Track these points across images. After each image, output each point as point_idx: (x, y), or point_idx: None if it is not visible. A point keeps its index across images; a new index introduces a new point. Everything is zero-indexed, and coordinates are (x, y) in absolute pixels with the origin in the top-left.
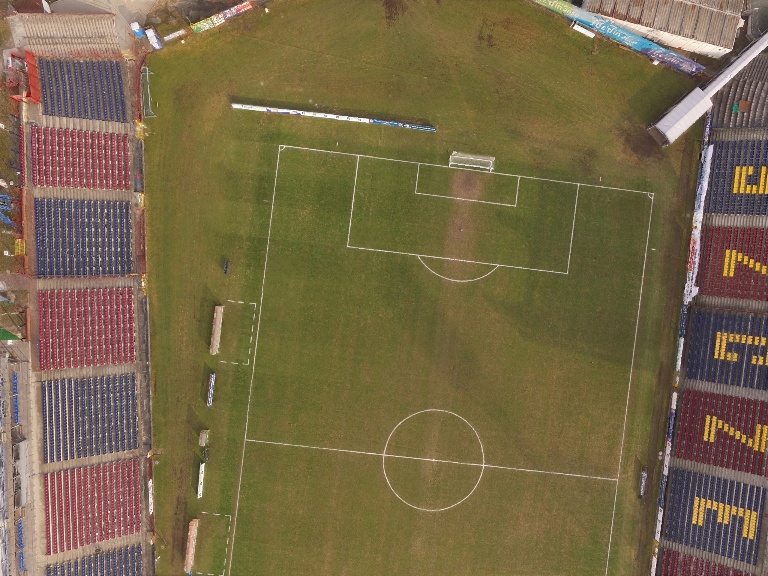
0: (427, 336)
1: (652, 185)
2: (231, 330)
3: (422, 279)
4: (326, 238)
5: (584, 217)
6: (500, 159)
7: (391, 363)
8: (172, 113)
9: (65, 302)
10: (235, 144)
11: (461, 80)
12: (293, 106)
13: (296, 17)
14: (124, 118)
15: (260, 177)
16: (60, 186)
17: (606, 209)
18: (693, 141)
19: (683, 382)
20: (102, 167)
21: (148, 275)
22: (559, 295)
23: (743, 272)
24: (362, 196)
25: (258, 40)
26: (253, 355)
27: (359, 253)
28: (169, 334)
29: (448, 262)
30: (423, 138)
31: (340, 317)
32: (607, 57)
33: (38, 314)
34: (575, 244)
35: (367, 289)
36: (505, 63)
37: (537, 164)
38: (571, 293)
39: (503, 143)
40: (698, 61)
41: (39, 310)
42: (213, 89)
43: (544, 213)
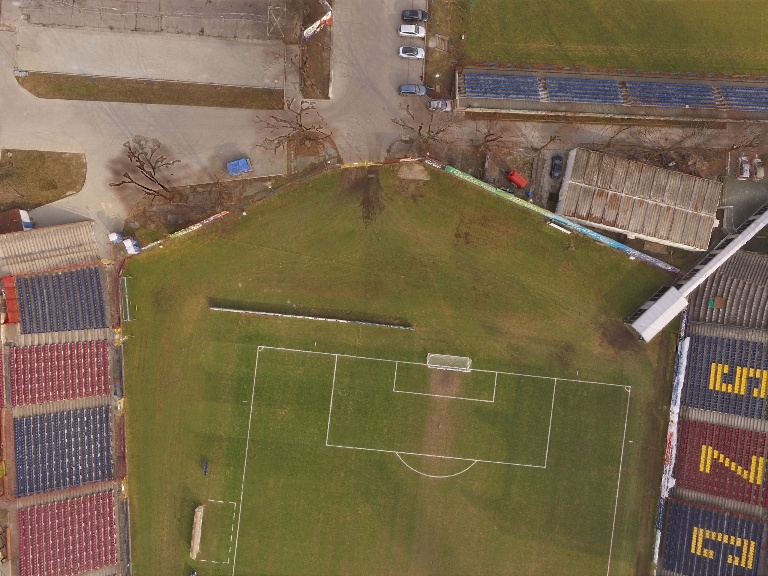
0: (406, 532)
1: (629, 378)
2: (211, 529)
3: (401, 476)
4: (305, 437)
5: (561, 411)
6: (477, 356)
7: (370, 559)
8: (151, 316)
9: (45, 516)
10: (214, 345)
11: (438, 278)
12: (271, 307)
13: (274, 219)
14: (103, 323)
15: (239, 378)
16: (39, 402)
17: (583, 403)
18: (669, 333)
19: (661, 572)
20: (81, 376)
21: (128, 477)
22: (537, 489)
23: (719, 470)
24: (340, 395)
25: (236, 242)
26: (233, 554)
27: (338, 451)
28: (150, 534)
29: (426, 458)
30: (401, 336)
31: (319, 515)
32: (583, 252)
33: (18, 533)
34: (553, 438)
35: (346, 487)
36: (482, 260)
37: (514, 360)
38: (549, 486)
39: (480, 340)
40: (674, 254)
41: (19, 529)
42: (192, 291)
43: (522, 408)
